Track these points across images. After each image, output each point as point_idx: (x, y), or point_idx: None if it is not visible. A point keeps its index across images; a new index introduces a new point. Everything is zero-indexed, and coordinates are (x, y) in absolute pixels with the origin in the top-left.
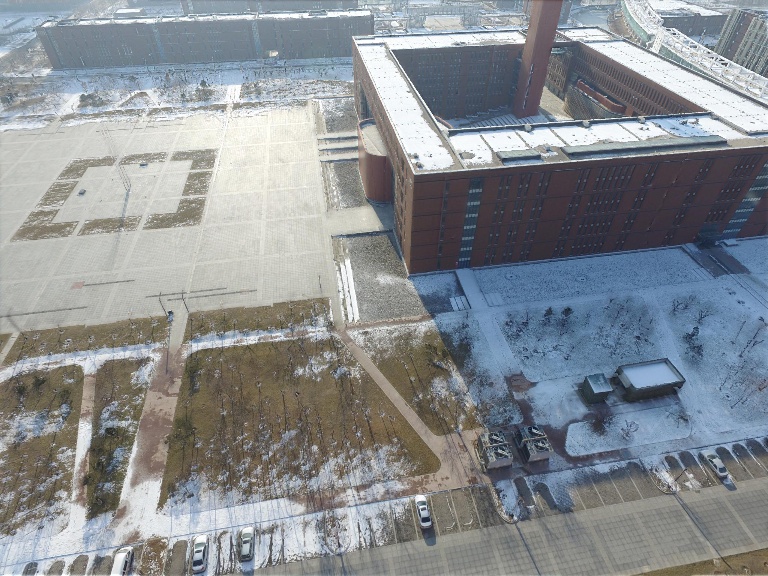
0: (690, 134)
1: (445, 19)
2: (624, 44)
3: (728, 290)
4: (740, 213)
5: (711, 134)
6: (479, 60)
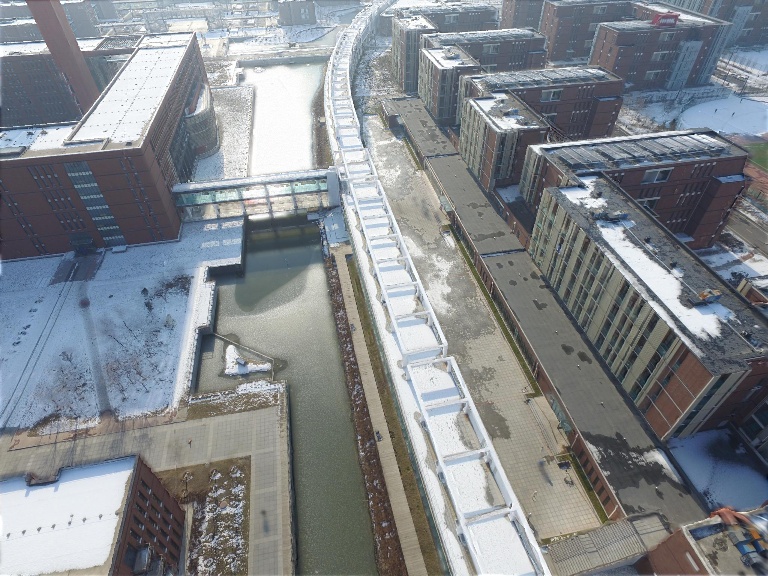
0: (10, 145)
1: (202, 22)
2: (179, 50)
3: (40, 298)
4: (101, 221)
5: (30, 145)
6: (35, 69)
